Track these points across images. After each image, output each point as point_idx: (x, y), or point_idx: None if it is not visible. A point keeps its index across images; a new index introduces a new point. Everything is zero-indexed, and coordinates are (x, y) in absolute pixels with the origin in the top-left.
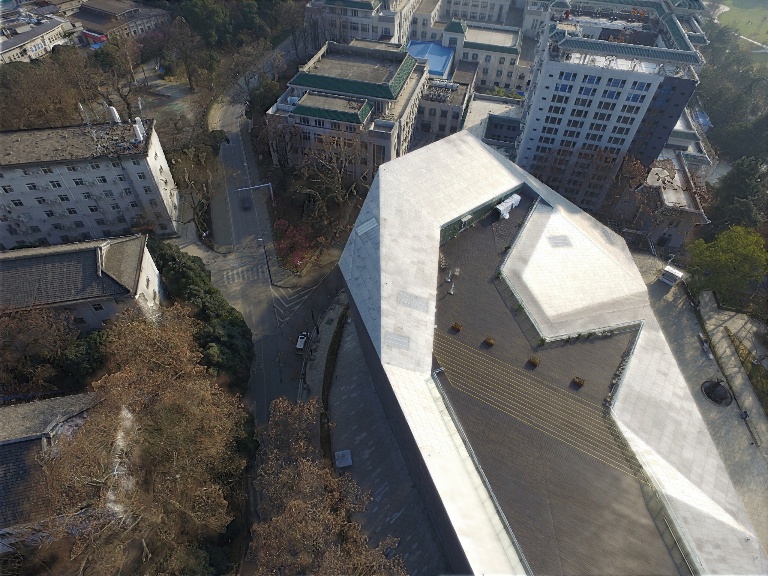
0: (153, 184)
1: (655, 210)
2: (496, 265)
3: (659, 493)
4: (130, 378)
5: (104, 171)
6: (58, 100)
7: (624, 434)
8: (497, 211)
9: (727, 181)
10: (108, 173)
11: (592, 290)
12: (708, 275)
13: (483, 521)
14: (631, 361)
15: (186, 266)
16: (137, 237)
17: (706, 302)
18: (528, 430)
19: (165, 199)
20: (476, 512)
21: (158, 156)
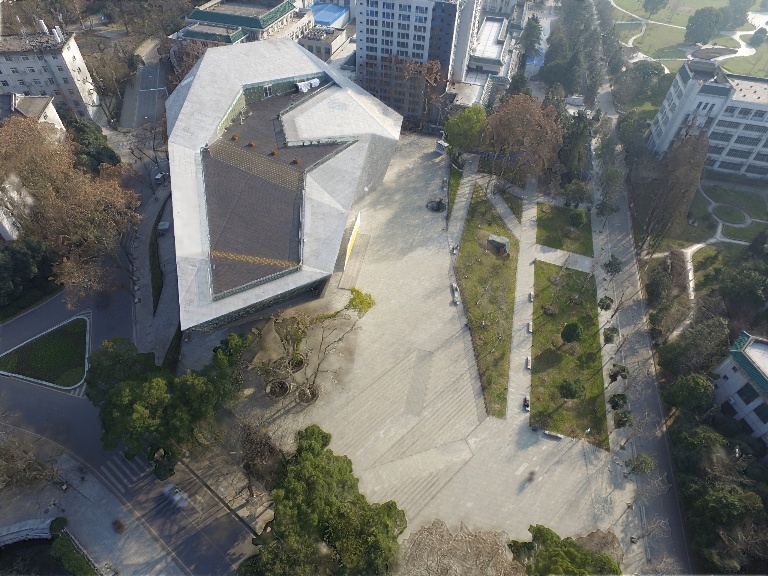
0: (69, 76)
1: (446, 107)
2: (281, 113)
3: (305, 197)
4: (7, 132)
5: (32, 62)
6: (9, 23)
7: (307, 180)
8: (296, 86)
9: (508, 90)
10: (35, 64)
11: (349, 133)
12: (451, 137)
13: (193, 200)
14: (338, 155)
15: (83, 124)
16: (45, 97)
17: (471, 168)
18: (245, 173)
19: (81, 91)
20: (191, 197)
21: (77, 60)
